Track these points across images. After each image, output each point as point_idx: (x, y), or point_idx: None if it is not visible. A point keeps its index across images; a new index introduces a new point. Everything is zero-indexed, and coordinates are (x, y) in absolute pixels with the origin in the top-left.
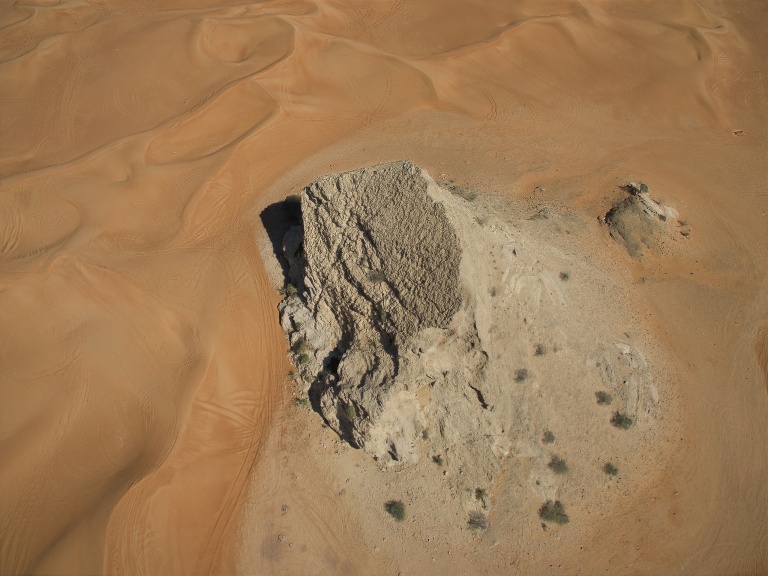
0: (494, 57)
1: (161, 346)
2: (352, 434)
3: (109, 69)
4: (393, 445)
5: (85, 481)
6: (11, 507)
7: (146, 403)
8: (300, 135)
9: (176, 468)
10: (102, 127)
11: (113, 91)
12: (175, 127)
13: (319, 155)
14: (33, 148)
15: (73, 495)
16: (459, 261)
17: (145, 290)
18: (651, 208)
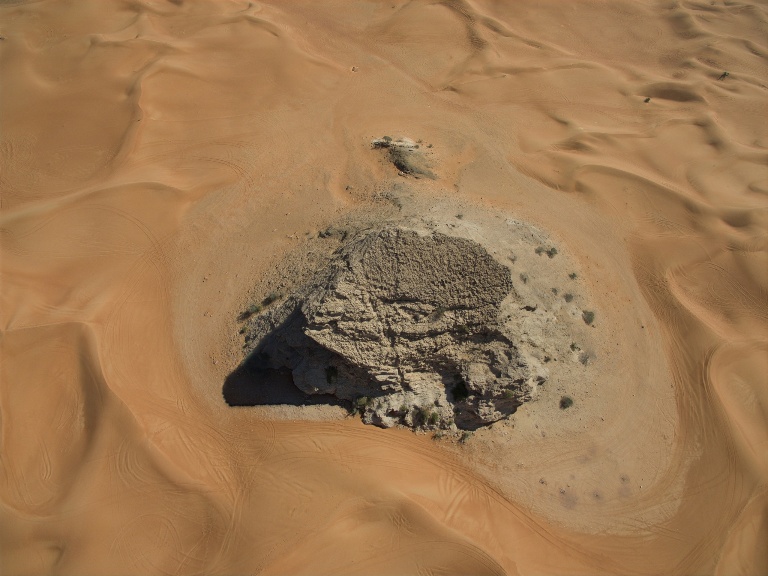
0: (161, 128)
1: (369, 546)
2: (510, 407)
3: None
4: (539, 378)
5: None
6: None
7: (428, 575)
8: (136, 325)
9: (503, 555)
10: None
11: None
12: None
13: (179, 320)
14: None
15: None
16: (485, 251)
17: (299, 545)
18: (409, 146)
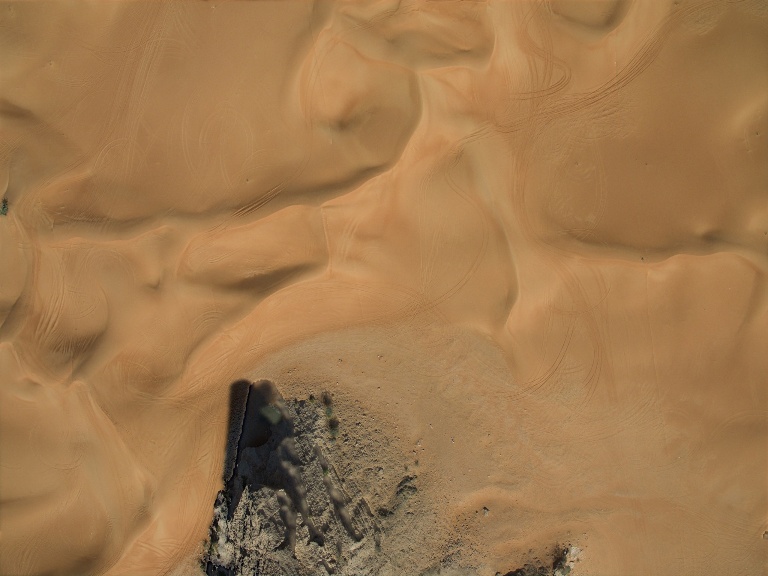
0: (631, 284)
1: (130, 488)
2: None
3: (192, 54)
4: None
5: (68, 548)
6: (31, 535)
7: (110, 523)
8: (334, 303)
9: (113, 575)
10: (160, 169)
11: (185, 108)
12: (220, 230)
13: (338, 336)
14: (94, 157)
15: (61, 552)
16: None
17: (129, 448)
18: None
